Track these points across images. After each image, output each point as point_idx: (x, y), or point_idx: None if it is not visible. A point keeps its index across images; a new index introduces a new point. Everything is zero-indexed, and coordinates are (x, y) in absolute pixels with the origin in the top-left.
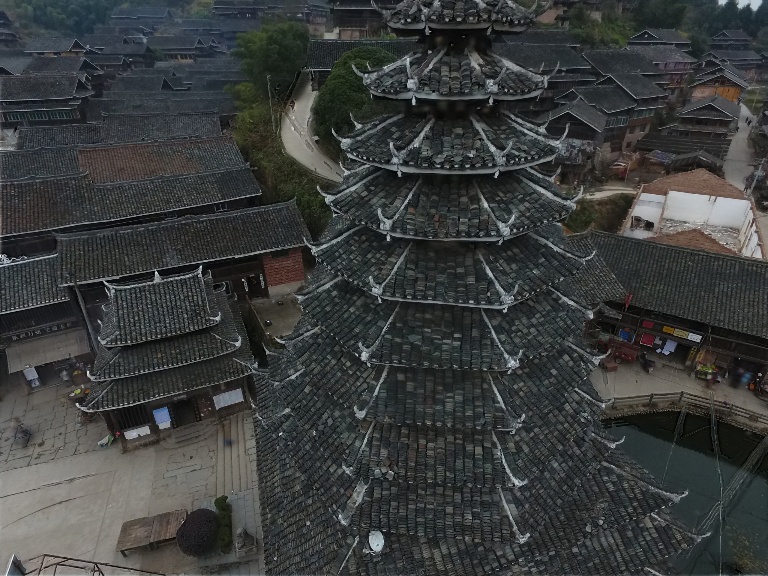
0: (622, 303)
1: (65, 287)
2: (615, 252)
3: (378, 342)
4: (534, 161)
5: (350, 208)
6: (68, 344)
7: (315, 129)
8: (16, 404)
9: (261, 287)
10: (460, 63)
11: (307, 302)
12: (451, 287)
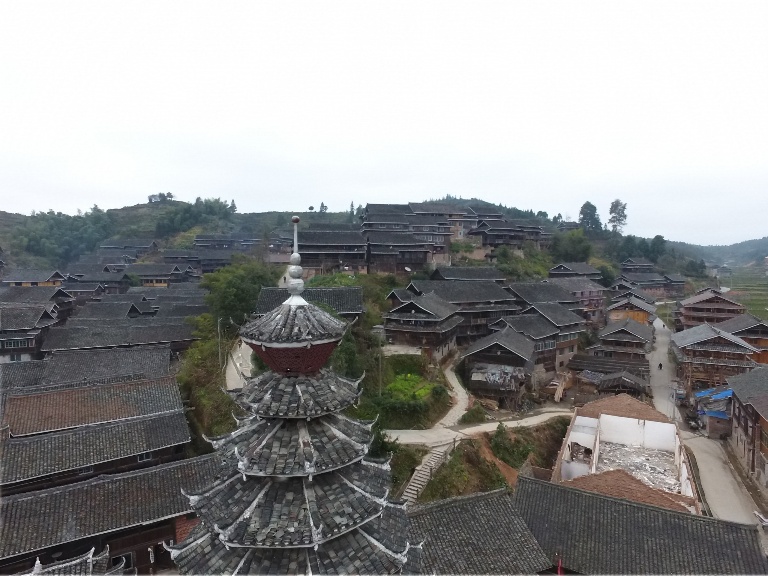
0: (556, 566)
1: None
2: (543, 501)
3: None
4: (357, 524)
5: (189, 569)
6: None
7: (254, 373)
8: None
9: None
10: (291, 437)
11: None
12: None
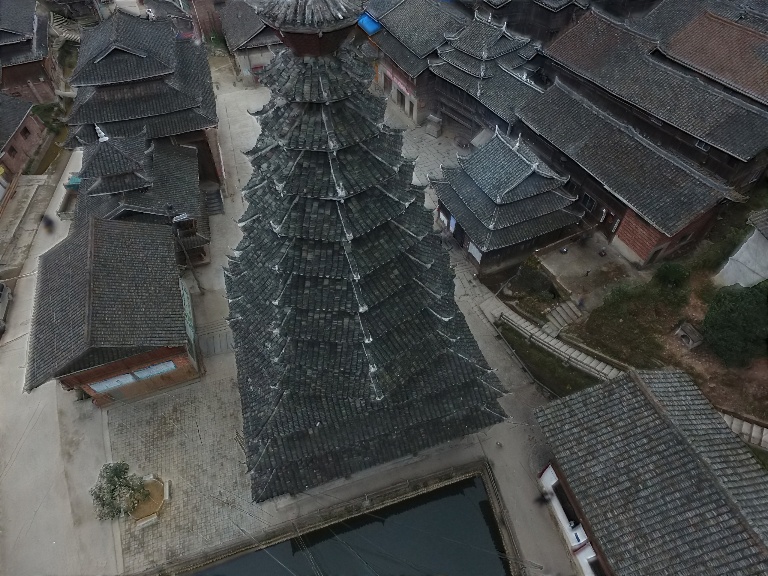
0: None
1: None
2: None
3: None
4: None
5: None
6: None
7: None
8: None
9: (612, 230)
10: None
11: None
12: None
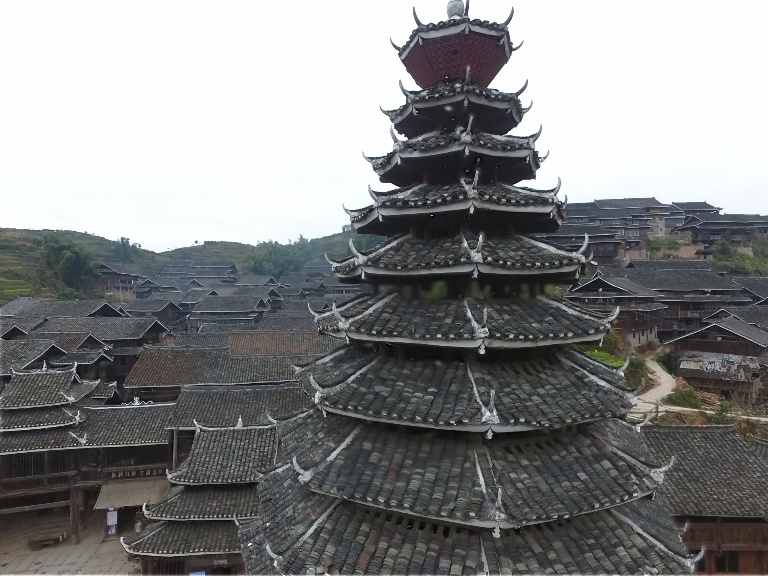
0: None
1: (169, 431)
2: None
3: (339, 388)
4: (521, 206)
5: None
6: (152, 491)
7: None
8: (87, 549)
9: None
10: None
11: (302, 373)
12: (423, 326)
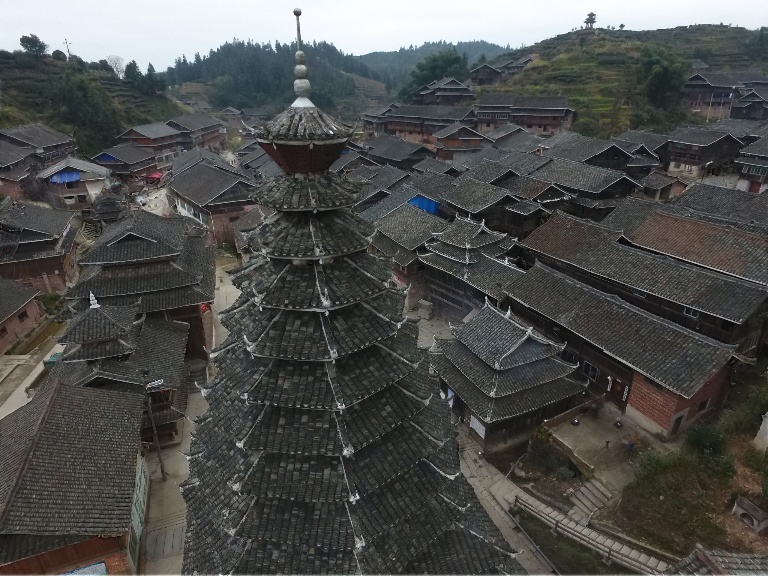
0: None
1: None
2: None
3: None
4: None
5: None
6: None
7: None
8: None
9: (622, 398)
10: None
11: None
12: None
